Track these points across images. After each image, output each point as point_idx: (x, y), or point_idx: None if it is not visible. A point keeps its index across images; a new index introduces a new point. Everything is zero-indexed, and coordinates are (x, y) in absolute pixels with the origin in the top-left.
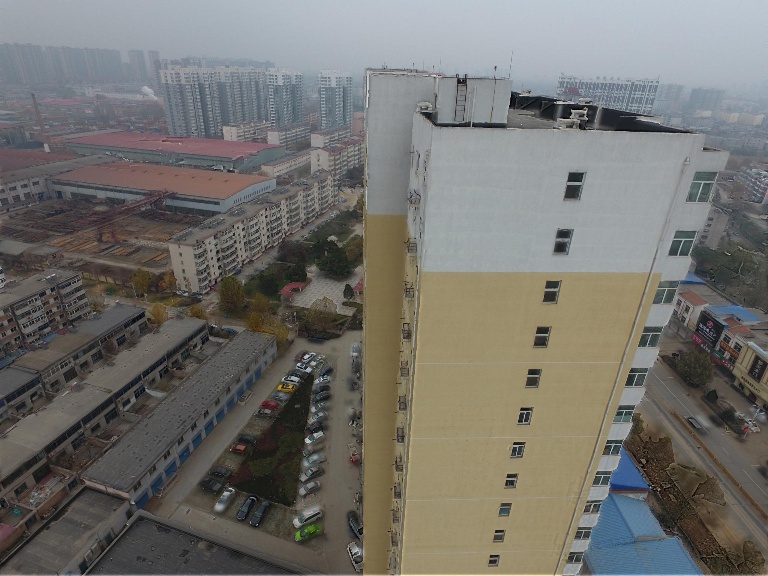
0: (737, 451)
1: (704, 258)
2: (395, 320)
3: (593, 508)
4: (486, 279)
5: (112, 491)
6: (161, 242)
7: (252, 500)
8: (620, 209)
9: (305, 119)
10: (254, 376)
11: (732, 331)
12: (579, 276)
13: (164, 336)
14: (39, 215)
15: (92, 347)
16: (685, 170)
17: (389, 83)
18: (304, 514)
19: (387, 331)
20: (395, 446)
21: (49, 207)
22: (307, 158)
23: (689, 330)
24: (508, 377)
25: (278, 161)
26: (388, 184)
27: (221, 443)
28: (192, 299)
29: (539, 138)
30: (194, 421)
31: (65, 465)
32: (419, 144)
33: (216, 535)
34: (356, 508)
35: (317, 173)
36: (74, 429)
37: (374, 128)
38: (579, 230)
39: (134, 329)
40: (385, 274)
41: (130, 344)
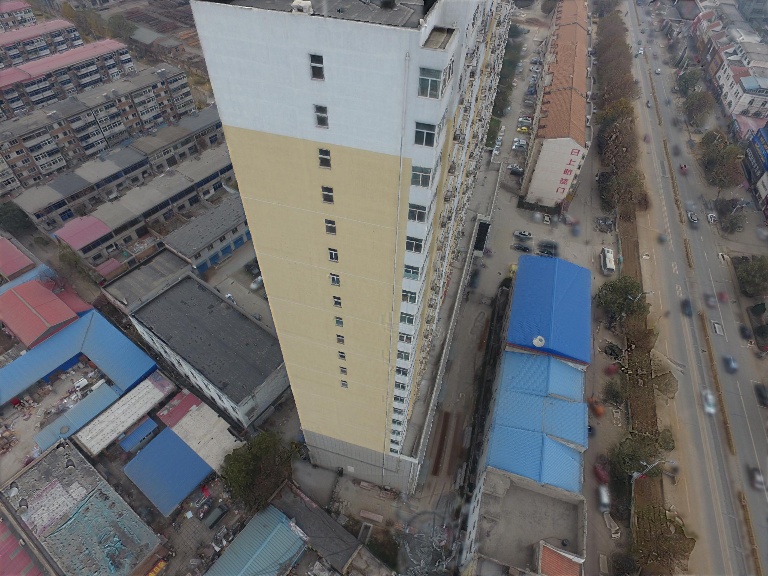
0: (746, 365)
1: None
2: None
3: (406, 339)
4: (270, 139)
5: (181, 255)
6: None
7: None
8: (360, 94)
9: None
10: None
11: None
12: (342, 149)
13: None
14: (172, 3)
15: (189, 141)
16: (407, 65)
17: None
18: None
19: None
20: None
21: None
22: None
23: None
24: (311, 222)
25: None
26: None
27: None
28: None
29: (274, 19)
30: None
31: (156, 230)
32: None
33: (247, 304)
34: None
35: None
36: (164, 205)
37: None
38: (331, 108)
39: None
40: None
41: (218, 144)
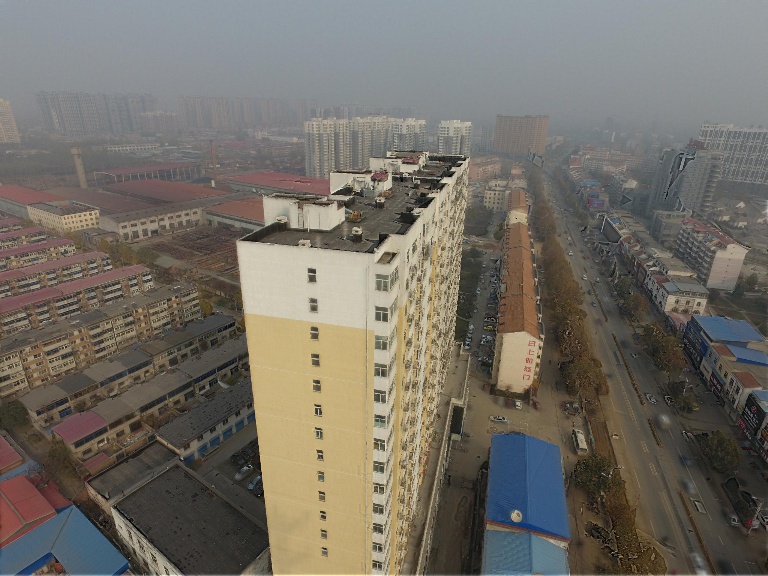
0: (736, 544)
1: None
2: None
3: (380, 490)
4: (277, 321)
5: (170, 447)
6: None
7: None
8: (339, 290)
9: None
10: None
11: None
12: (327, 326)
13: (241, 343)
14: (192, 238)
15: (192, 343)
16: (368, 273)
17: (273, 202)
18: None
19: None
20: None
21: (200, 232)
22: None
23: (738, 413)
24: (302, 382)
25: None
26: None
27: None
28: None
29: (287, 250)
30: (238, 409)
31: (150, 423)
32: None
33: (230, 496)
34: None
35: None
36: (161, 400)
37: None
38: (320, 300)
39: (225, 334)
40: None
41: (218, 345)
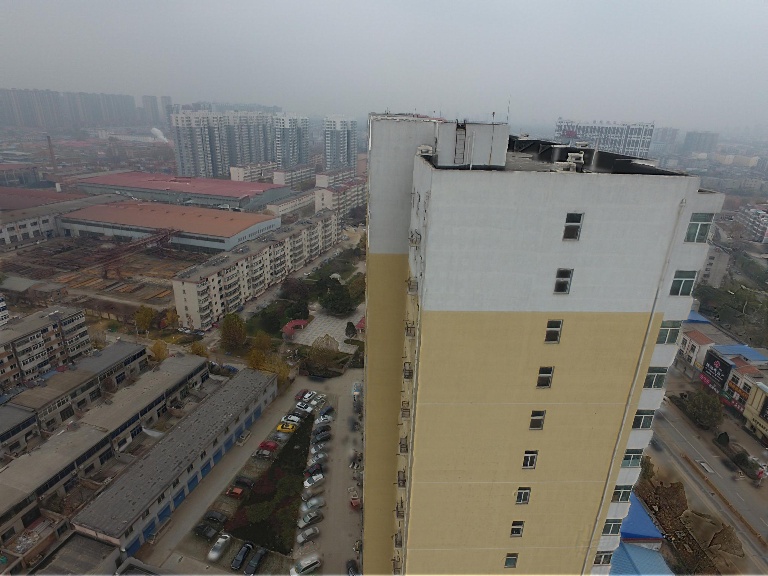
0: (753, 498)
1: (707, 297)
2: (396, 359)
3: (604, 559)
4: (487, 318)
5: (102, 537)
6: (165, 279)
7: (247, 548)
8: (619, 249)
9: (310, 160)
10: (253, 415)
11: (740, 371)
12: (581, 315)
13: (164, 374)
14: (46, 252)
15: (91, 385)
16: (682, 211)
17: (391, 128)
18: (301, 563)
19: (388, 370)
20: (396, 490)
21: (57, 244)
22: (311, 198)
23: (696, 370)
24: (511, 419)
25: (283, 200)
26: (390, 224)
27: (217, 486)
28: (194, 336)
29: (537, 180)
30: (190, 462)
31: (56, 508)
32: (420, 185)
33: None
34: (356, 557)
35: (321, 212)
36: (67, 470)
37: (376, 170)
38: (579, 270)
39: (134, 366)
40: (386, 312)
41: (129, 382)
